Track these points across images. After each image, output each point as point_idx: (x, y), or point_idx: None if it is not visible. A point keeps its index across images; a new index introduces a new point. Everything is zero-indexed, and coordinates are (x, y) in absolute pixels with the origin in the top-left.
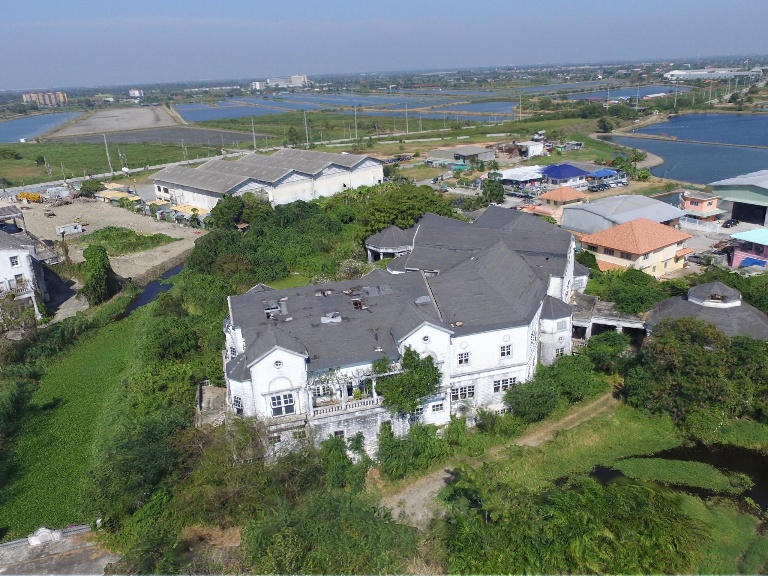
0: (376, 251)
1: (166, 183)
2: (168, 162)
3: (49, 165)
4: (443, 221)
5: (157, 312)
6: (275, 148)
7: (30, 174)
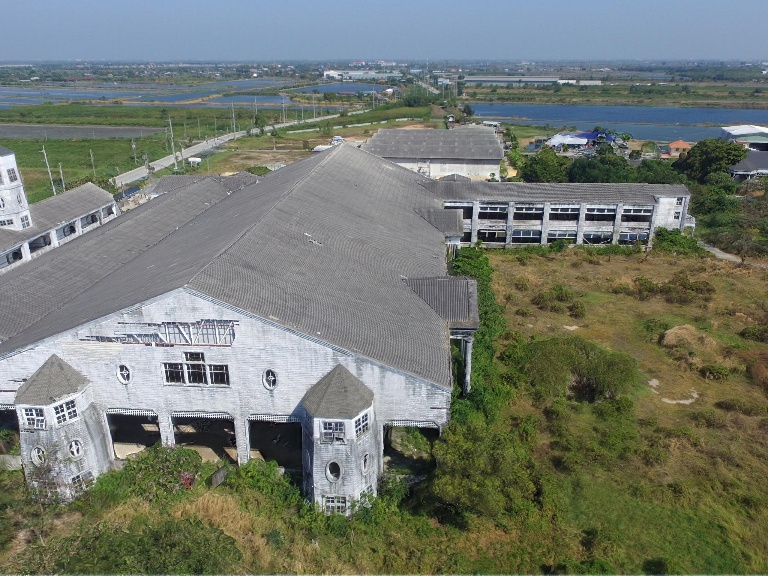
0: (745, 174)
1: (395, 159)
2: (160, 154)
3: (145, 157)
4: (764, 153)
5: (765, 214)
6: (229, 137)
7: (34, 176)
